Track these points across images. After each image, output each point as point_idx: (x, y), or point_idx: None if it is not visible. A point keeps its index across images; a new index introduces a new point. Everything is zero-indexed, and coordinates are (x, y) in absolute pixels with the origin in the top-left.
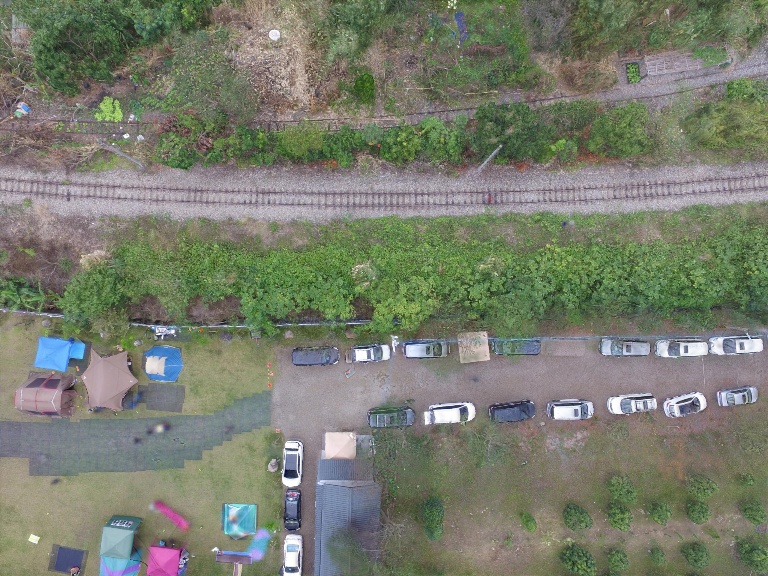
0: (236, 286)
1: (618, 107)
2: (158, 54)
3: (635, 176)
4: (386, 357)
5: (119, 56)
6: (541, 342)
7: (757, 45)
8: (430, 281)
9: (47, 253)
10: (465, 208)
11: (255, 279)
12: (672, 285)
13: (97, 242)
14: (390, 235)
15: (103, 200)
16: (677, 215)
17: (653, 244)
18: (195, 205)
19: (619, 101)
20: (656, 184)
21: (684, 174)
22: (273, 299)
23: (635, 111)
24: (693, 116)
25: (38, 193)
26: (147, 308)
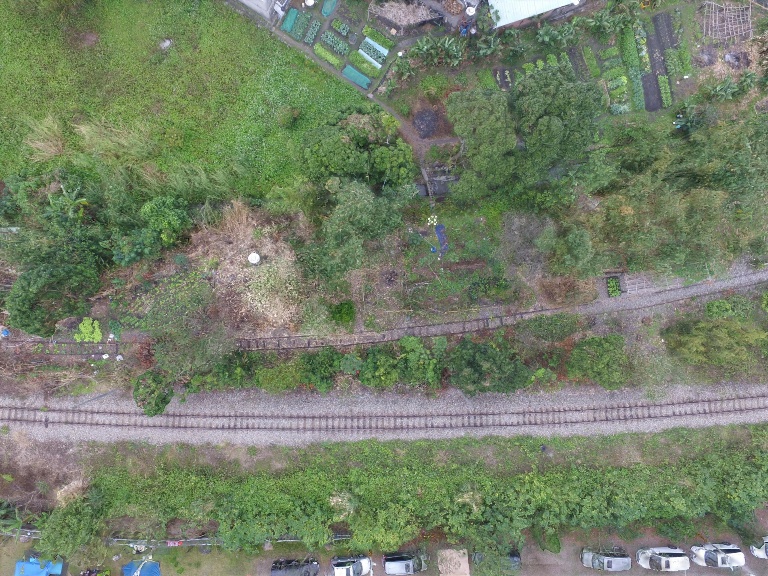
0: (214, 513)
1: (597, 339)
2: (137, 281)
3: (615, 398)
4: (366, 571)
5: (98, 285)
6: (522, 550)
7: (738, 257)
8: (409, 507)
9: (25, 478)
10: (444, 431)
11: (232, 511)
12: (653, 504)
13: (75, 467)
14: (369, 459)
15: (81, 426)
16: (657, 437)
17: (633, 468)
18: (173, 430)
19: (600, 314)
20: (636, 406)
21: (664, 395)
22: (251, 530)
23: (613, 352)
24: (674, 331)
25: (16, 420)
26: (126, 524)
